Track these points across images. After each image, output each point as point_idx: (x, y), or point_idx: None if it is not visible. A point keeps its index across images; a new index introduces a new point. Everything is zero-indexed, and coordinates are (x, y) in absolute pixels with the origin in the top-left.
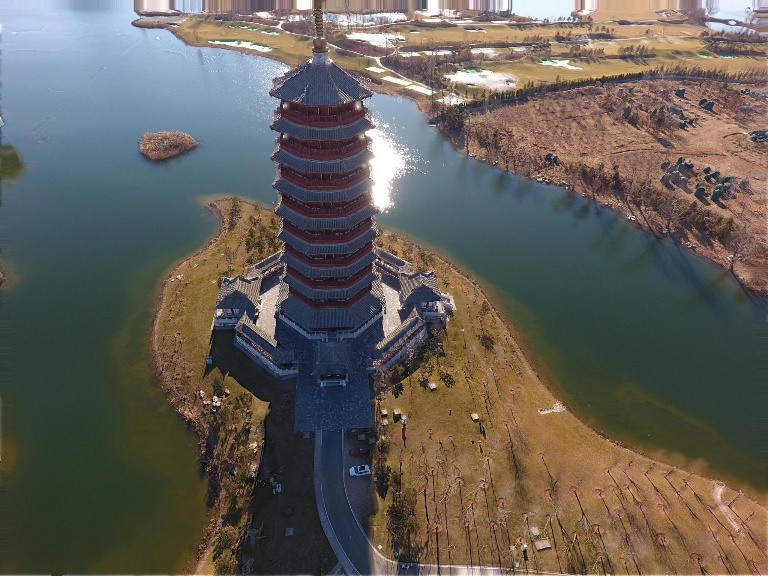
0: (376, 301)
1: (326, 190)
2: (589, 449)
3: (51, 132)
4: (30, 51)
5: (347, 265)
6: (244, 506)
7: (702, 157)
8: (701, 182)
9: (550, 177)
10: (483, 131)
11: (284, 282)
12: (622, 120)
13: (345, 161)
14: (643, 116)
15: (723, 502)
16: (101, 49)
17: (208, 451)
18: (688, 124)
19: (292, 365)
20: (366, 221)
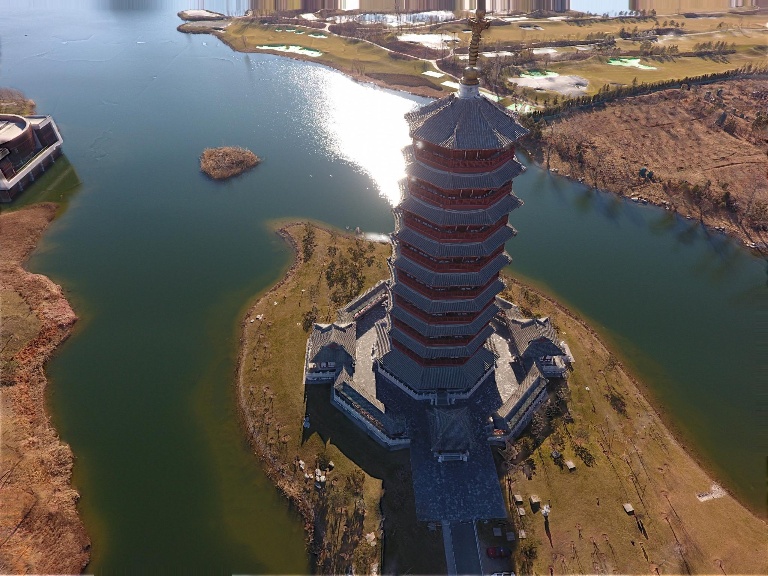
0: (489, 355)
1: (460, 243)
2: None
3: (109, 149)
4: (81, 61)
5: (470, 322)
6: None
7: None
8: None
9: (647, 196)
10: (563, 143)
11: (383, 331)
12: (717, 128)
13: (488, 210)
14: (740, 123)
15: None
16: (150, 57)
17: (317, 539)
18: None
19: (402, 433)
20: None
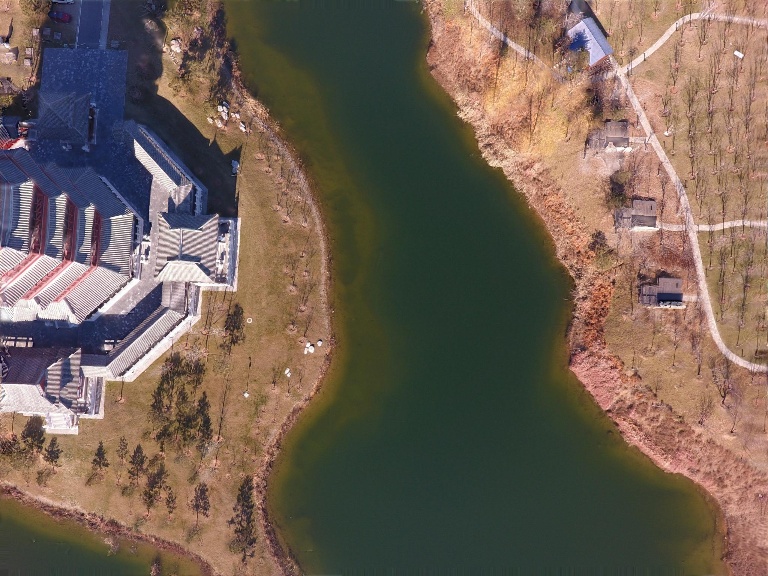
0: None
1: None
2: None
3: None
4: None
5: None
6: None
7: None
8: None
9: None
10: None
11: None
12: None
13: None
14: None
15: None
16: None
17: (229, 62)
18: None
19: None
20: None
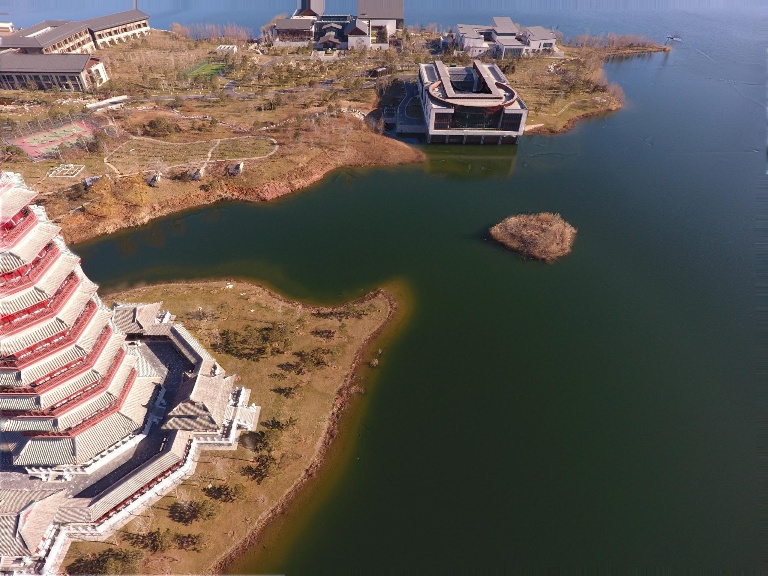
0: (21, 450)
1: None
2: None
3: (538, 162)
4: (755, 104)
5: None
6: None
7: None
8: None
9: None
10: None
11: None
12: None
13: None
14: None
15: None
16: None
17: None
18: None
19: None
20: None
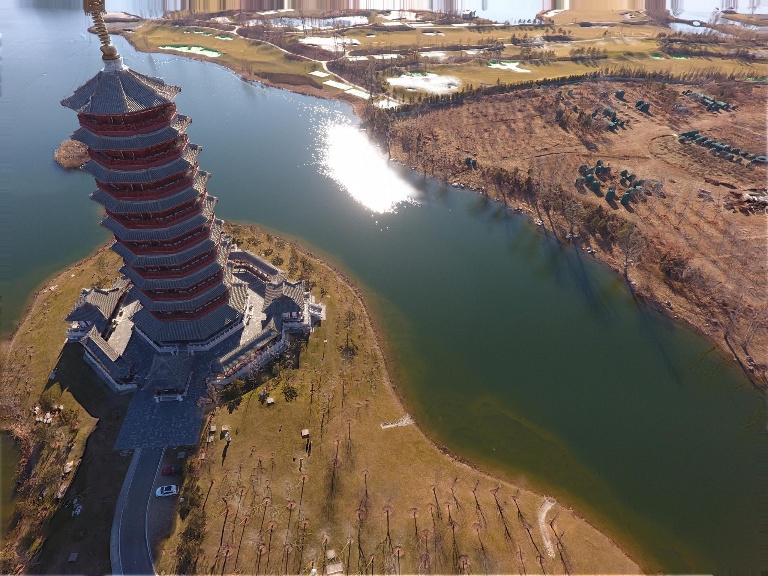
0: (233, 312)
1: (139, 201)
2: (422, 465)
3: None
4: None
5: (183, 277)
6: (30, 530)
7: (624, 160)
8: (613, 185)
9: (466, 181)
10: (409, 135)
11: None
12: (553, 123)
13: (152, 171)
14: None
15: (546, 520)
16: (48, 56)
17: (26, 470)
18: (619, 126)
19: (132, 379)
20: (202, 231)
